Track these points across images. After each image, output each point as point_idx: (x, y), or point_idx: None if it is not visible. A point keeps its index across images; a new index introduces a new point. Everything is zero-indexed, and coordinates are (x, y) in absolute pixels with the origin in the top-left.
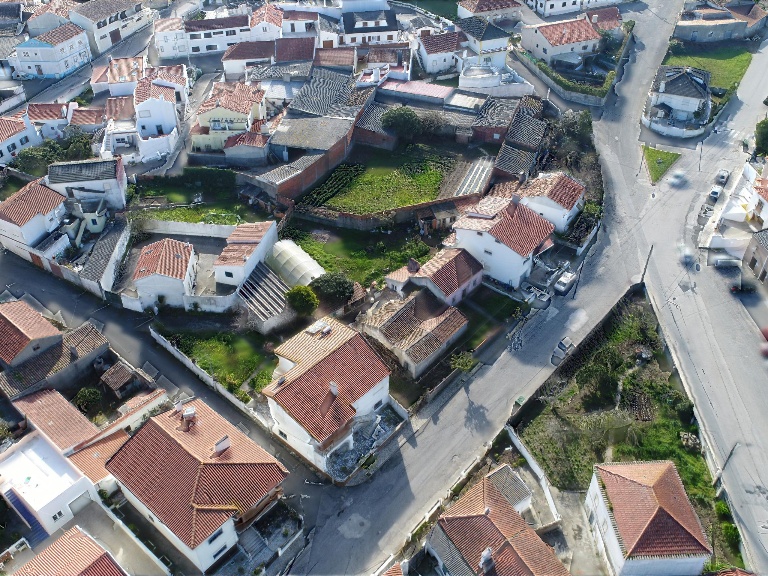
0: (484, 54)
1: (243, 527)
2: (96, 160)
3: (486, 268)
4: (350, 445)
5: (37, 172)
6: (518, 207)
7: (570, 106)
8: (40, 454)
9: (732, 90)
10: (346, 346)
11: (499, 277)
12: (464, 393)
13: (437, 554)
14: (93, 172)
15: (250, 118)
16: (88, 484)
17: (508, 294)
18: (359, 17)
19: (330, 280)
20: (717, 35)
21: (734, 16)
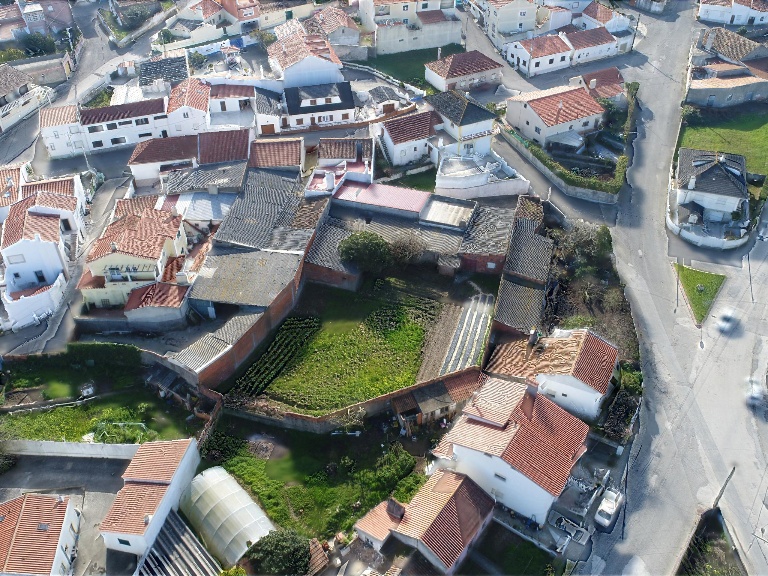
0: (464, 141)
1: None
2: None
3: (497, 494)
4: None
5: None
6: (536, 400)
7: (576, 206)
8: None
9: None
10: None
11: (516, 508)
12: None
13: None
14: None
15: (161, 260)
16: None
17: (532, 539)
18: (305, 93)
19: (274, 551)
20: (737, 98)
21: (753, 73)
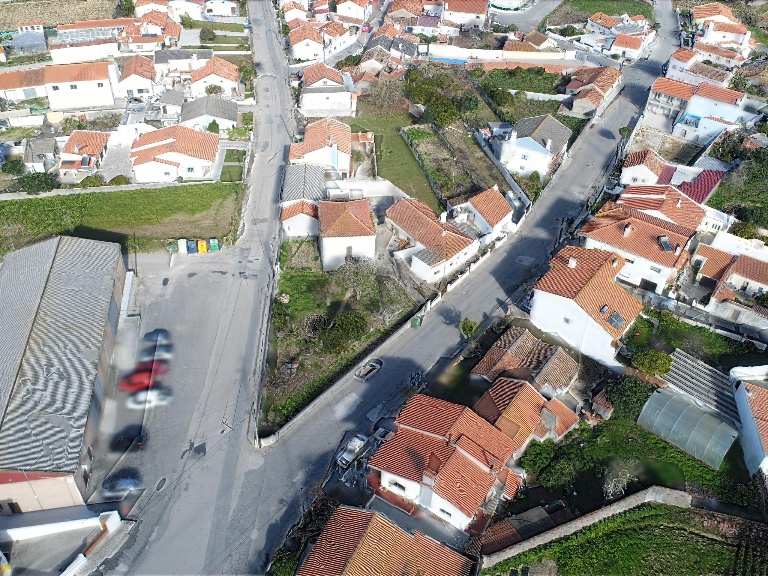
0: None
1: None
2: None
3: None
4: None
5: None
6: None
7: None
8: None
9: None
10: None
11: None
12: None
13: None
14: None
15: None
16: None
17: None
18: None
19: (636, 380)
20: None
21: None
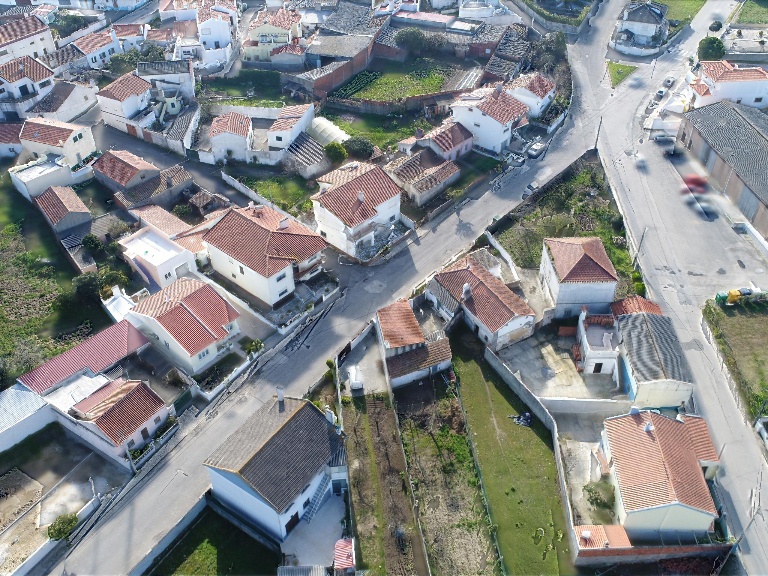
0: None
1: (299, 276)
2: (173, 60)
3: (476, 139)
4: (372, 242)
5: (125, 72)
6: (501, 93)
7: None
8: (152, 240)
9: (686, 21)
10: (369, 173)
11: (486, 145)
12: (456, 216)
13: (433, 294)
14: (171, 68)
15: (290, 34)
16: (189, 254)
17: (492, 156)
18: None
19: (356, 140)
20: None
21: None
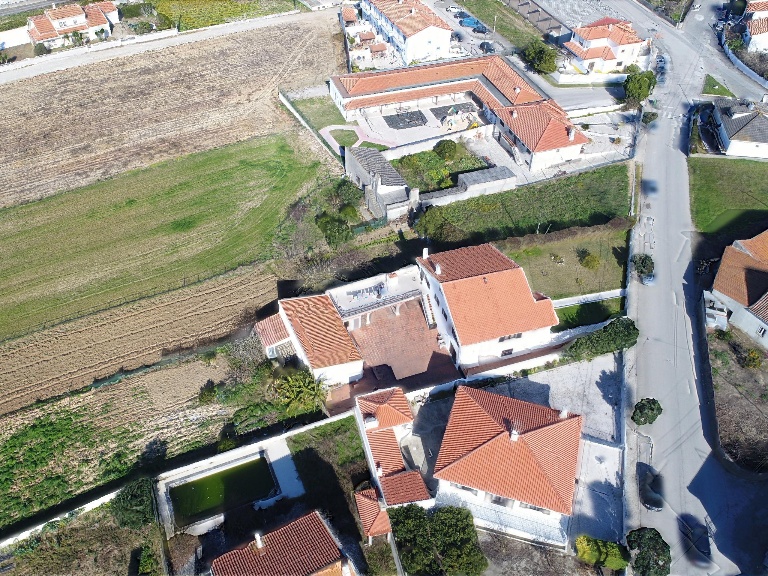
0: None
1: None
2: None
3: None
4: None
5: None
6: None
7: None
8: None
9: (694, 143)
10: None
11: None
12: None
13: None
14: None
15: None
16: None
17: None
18: None
19: None
20: None
21: None
